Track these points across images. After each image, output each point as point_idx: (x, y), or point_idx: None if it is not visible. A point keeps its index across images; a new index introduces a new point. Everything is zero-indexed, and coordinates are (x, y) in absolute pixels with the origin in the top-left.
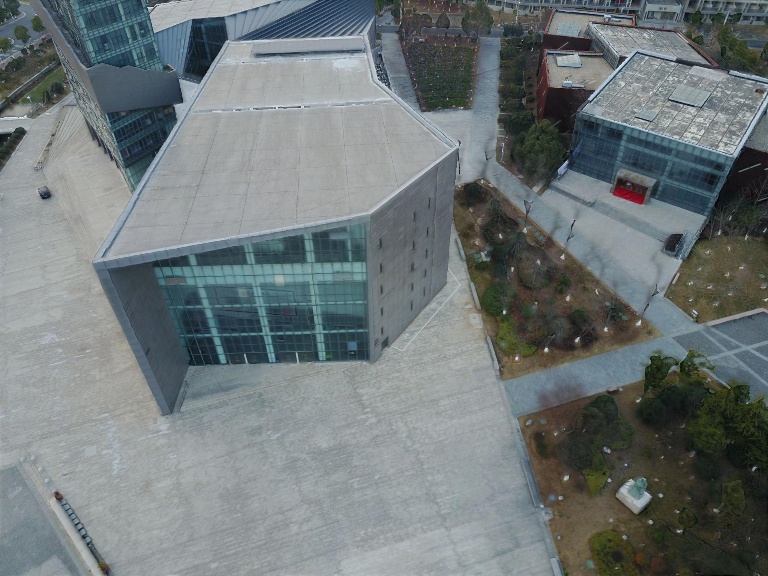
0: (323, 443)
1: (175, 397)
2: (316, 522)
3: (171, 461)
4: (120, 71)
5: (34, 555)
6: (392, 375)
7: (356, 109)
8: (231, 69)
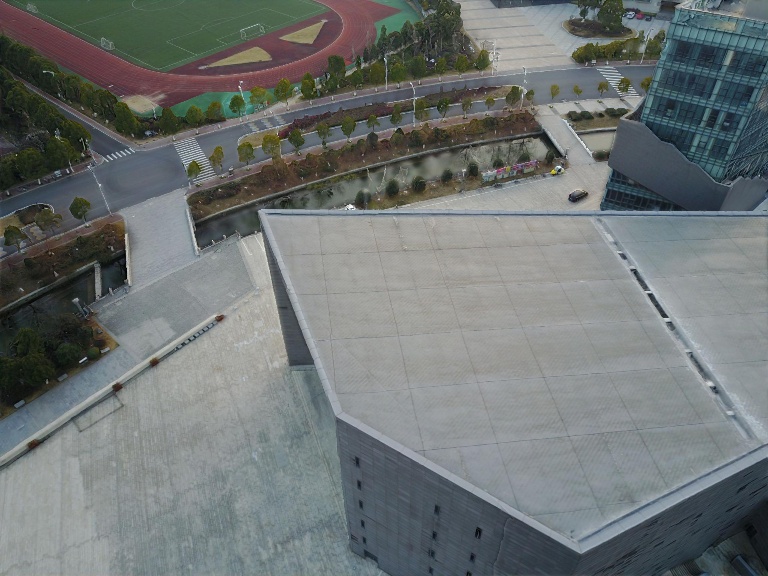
0: (240, 504)
1: (305, 362)
2: (153, 509)
3: (239, 379)
4: (657, 143)
5: (179, 322)
6: (331, 575)
7: (689, 387)
8: (761, 231)
